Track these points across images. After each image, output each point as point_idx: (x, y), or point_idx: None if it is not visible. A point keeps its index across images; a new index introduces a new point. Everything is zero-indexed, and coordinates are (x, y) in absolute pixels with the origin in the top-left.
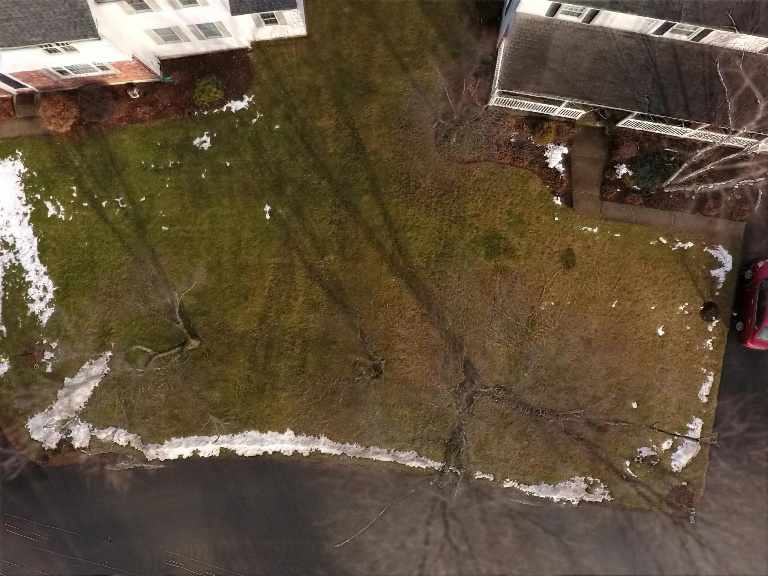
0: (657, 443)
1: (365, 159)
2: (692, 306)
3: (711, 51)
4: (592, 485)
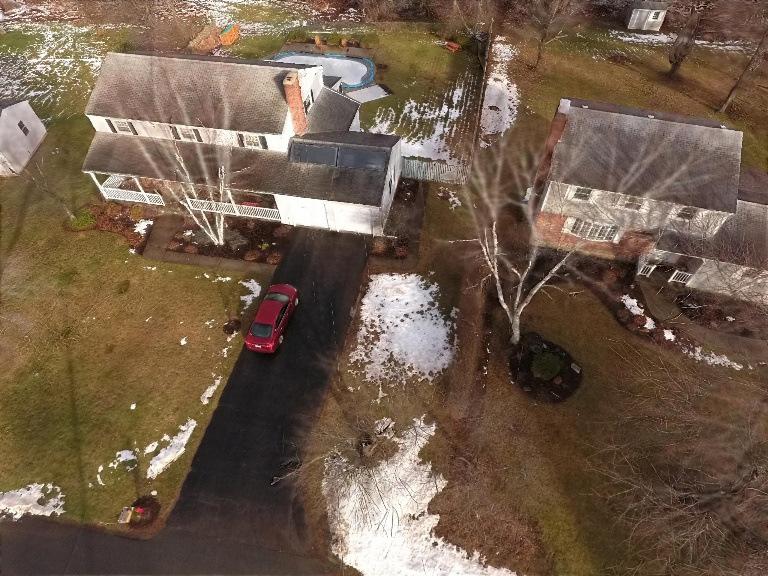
0: (141, 446)
1: (8, 231)
2: (218, 322)
3: (212, 147)
4: (48, 494)
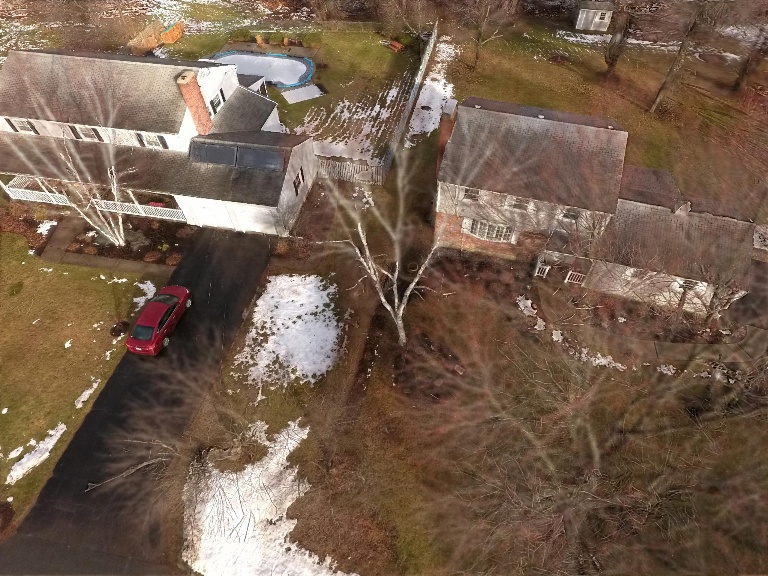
0: (5, 451)
1: None
2: (106, 324)
3: (113, 147)
4: None
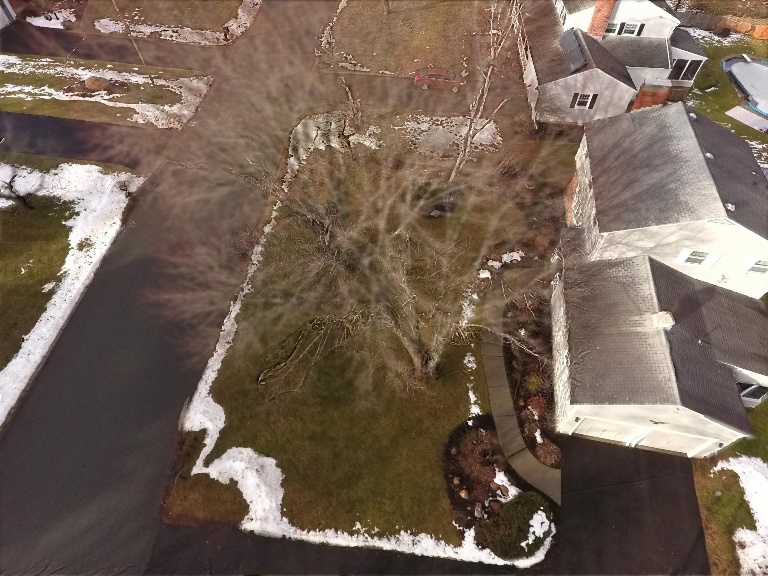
0: None
1: (476, 2)
2: None
3: None
4: None
